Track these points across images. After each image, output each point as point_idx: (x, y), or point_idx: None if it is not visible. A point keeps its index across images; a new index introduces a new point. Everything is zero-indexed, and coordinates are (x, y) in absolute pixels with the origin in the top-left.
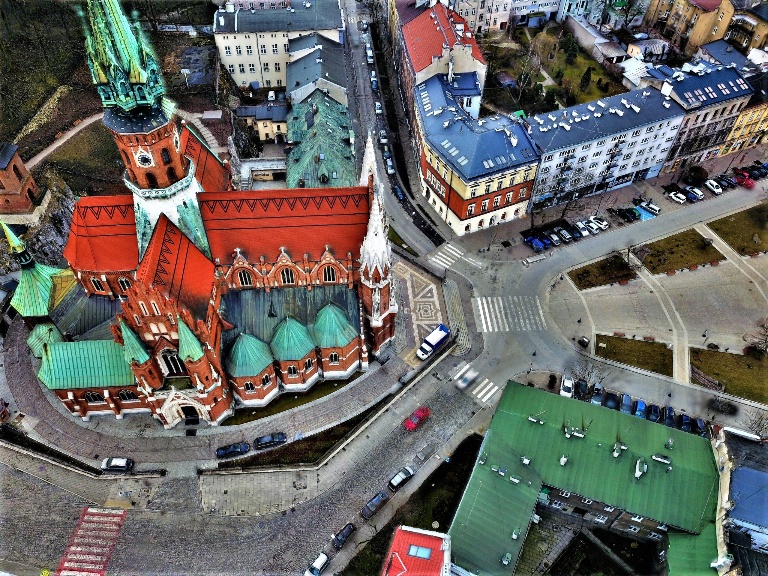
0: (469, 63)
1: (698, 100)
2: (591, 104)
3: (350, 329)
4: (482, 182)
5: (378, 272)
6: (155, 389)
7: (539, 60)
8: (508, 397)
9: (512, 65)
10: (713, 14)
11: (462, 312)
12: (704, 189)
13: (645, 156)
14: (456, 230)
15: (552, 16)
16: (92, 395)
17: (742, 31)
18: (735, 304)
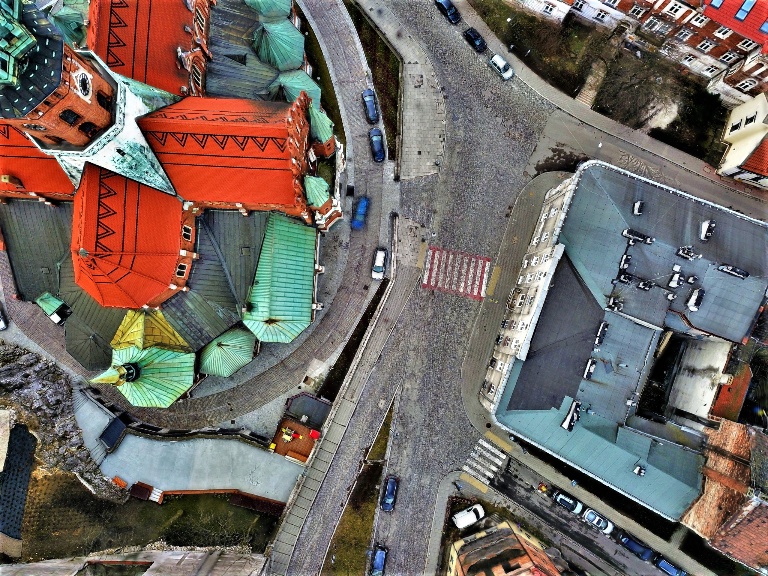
0: None
1: None
2: None
3: None
4: None
5: None
6: None
7: None
8: None
9: None
10: None
11: None
12: None
13: None
14: None
15: None
16: None
17: None
18: None
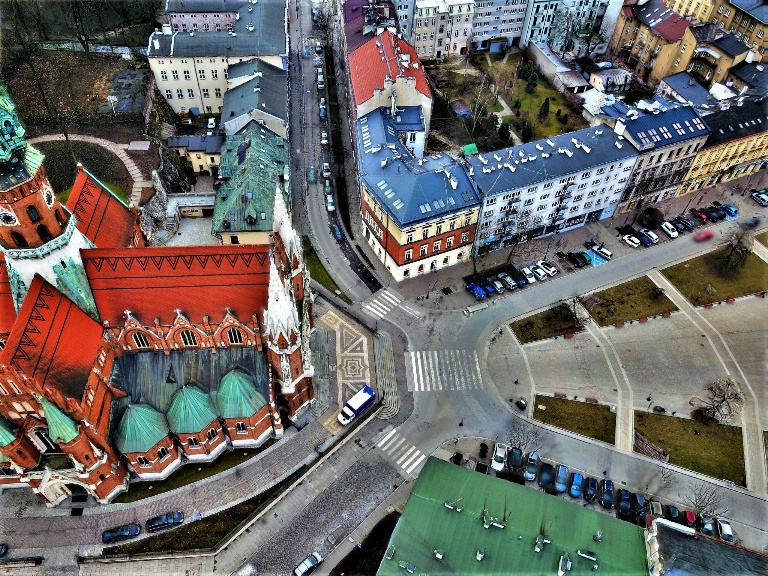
0: (413, 96)
1: (652, 141)
2: (539, 143)
3: (258, 396)
4: (419, 227)
5: (284, 338)
6: (28, 469)
7: (496, 89)
8: (426, 477)
9: (465, 96)
10: (676, 46)
11: (393, 368)
12: (660, 232)
13: (597, 197)
14: (395, 275)
15: (515, 42)
16: None
17: (705, 64)
18: (685, 361)
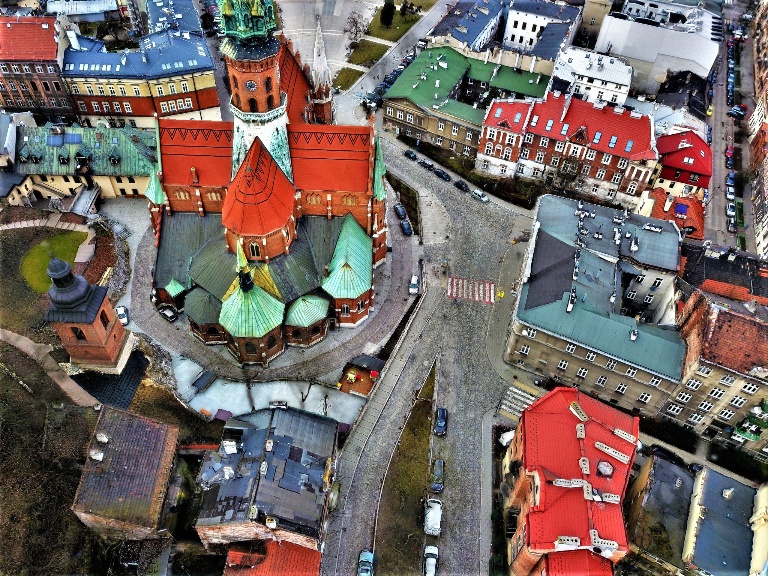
0: None
1: None
2: (158, 2)
3: None
4: None
5: None
6: None
7: None
8: None
9: None
10: None
11: None
12: None
13: None
14: None
15: None
16: None
17: None
18: None
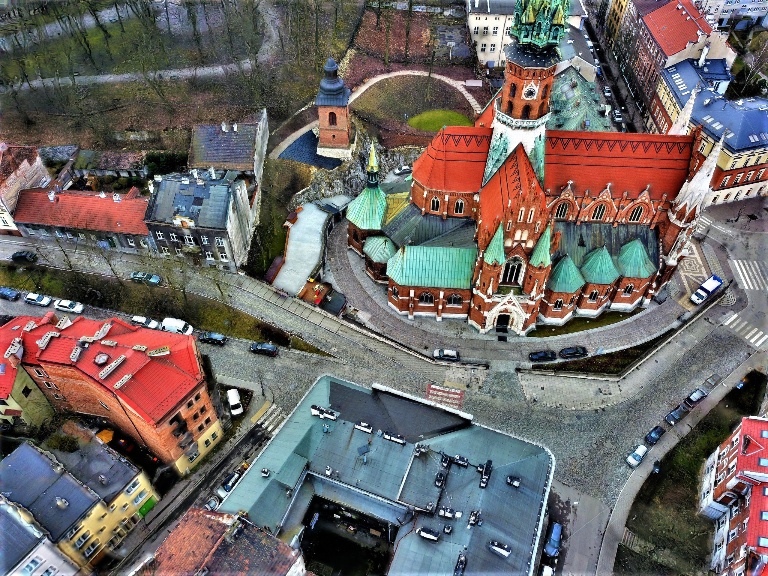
0: (721, 50)
1: None
2: None
3: (650, 264)
4: (745, 155)
5: (694, 212)
6: (493, 292)
7: None
8: None
9: (743, 59)
10: None
11: (722, 270)
12: None
13: None
14: None
15: (758, 21)
16: (426, 296)
17: None
18: None
